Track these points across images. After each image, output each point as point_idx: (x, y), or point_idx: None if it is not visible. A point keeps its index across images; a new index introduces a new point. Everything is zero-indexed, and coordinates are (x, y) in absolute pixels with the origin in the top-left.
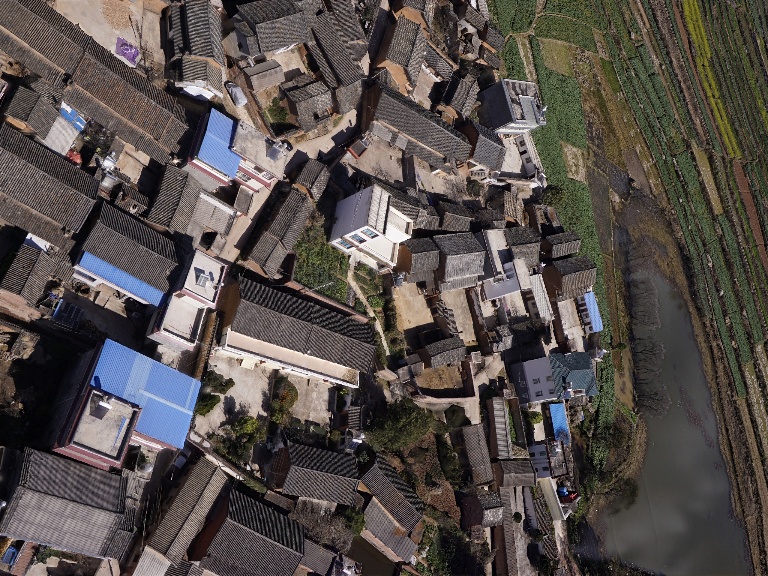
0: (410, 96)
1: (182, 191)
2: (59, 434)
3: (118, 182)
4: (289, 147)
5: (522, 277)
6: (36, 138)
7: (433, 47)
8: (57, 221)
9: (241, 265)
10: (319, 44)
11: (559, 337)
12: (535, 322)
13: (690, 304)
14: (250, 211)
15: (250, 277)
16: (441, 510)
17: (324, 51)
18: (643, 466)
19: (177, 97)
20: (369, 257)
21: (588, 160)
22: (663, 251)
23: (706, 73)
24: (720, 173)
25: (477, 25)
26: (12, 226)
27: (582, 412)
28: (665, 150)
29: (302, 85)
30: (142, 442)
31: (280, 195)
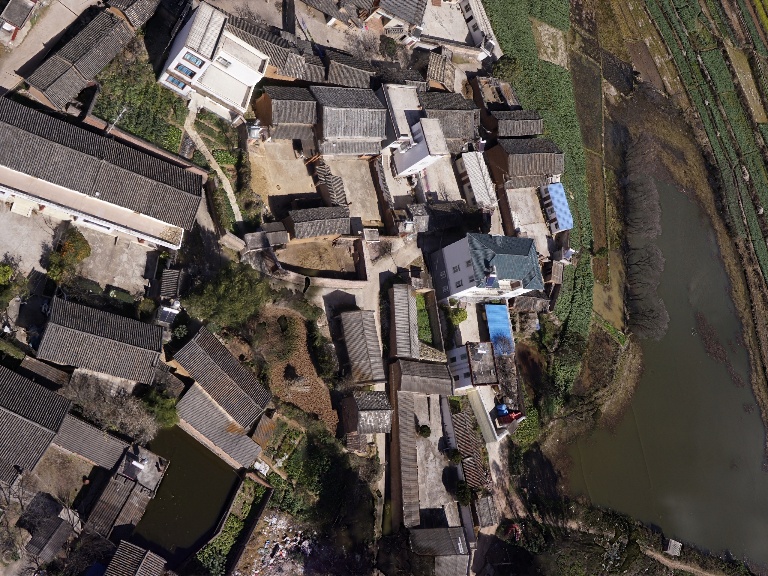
0: None
1: None
2: None
3: None
4: None
5: (433, 140)
6: None
7: None
8: None
9: (24, 95)
10: None
11: (508, 231)
12: None
13: (716, 220)
14: (43, 35)
15: None
16: (307, 411)
17: None
18: (633, 396)
19: None
20: (218, 104)
21: (573, 44)
22: (679, 157)
23: None
24: (764, 77)
25: None
26: None
27: (537, 320)
28: (686, 45)
29: None
30: None
31: None
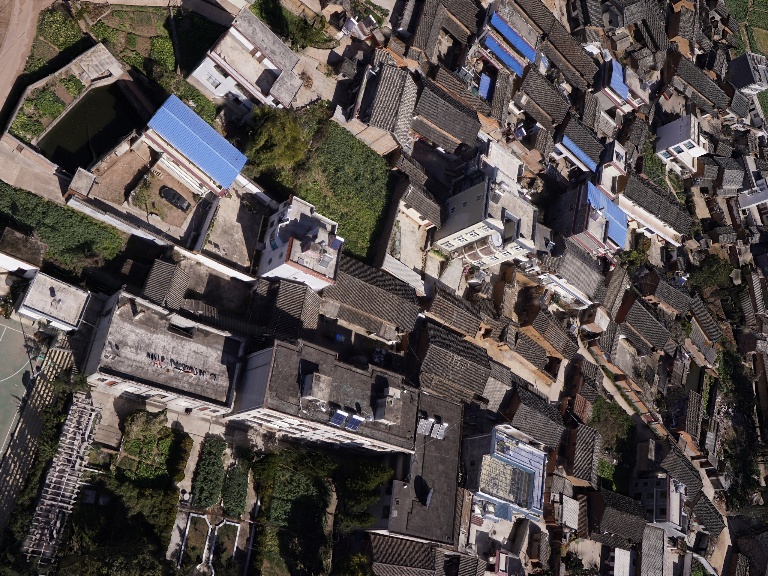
0: None
1: (596, 108)
2: (572, 229)
3: None
4: None
5: None
6: None
7: None
8: (553, 116)
9: None
10: (644, 23)
11: None
12: None
13: None
14: None
15: None
16: None
17: (648, 28)
18: None
19: None
20: (676, 166)
21: None
22: None
23: None
24: None
25: (723, 14)
26: (524, 119)
27: None
28: None
29: (637, 49)
30: None
31: (626, 121)
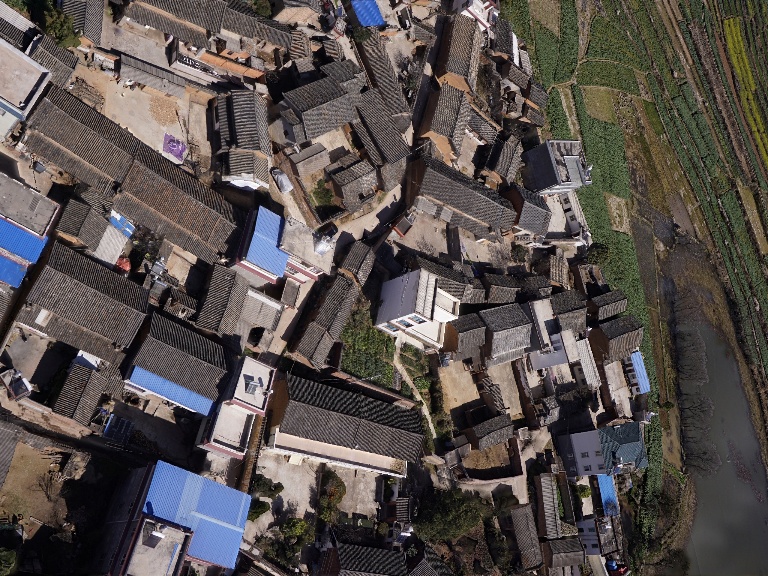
0: (454, 163)
1: (230, 291)
2: (112, 563)
3: (167, 286)
4: (334, 230)
5: (570, 349)
6: (87, 251)
7: (476, 110)
8: (108, 337)
9: (288, 357)
10: (364, 122)
11: (606, 402)
12: (582, 390)
13: (737, 351)
14: None
15: (297, 369)
16: None
17: (369, 129)
18: (692, 529)
19: (224, 190)
20: None
21: (632, 209)
22: (709, 298)
23: (751, 107)
24: (766, 211)
25: (520, 84)
26: None
27: (630, 479)
28: (710, 191)
29: (347, 166)
30: (193, 559)
31: (326, 280)
